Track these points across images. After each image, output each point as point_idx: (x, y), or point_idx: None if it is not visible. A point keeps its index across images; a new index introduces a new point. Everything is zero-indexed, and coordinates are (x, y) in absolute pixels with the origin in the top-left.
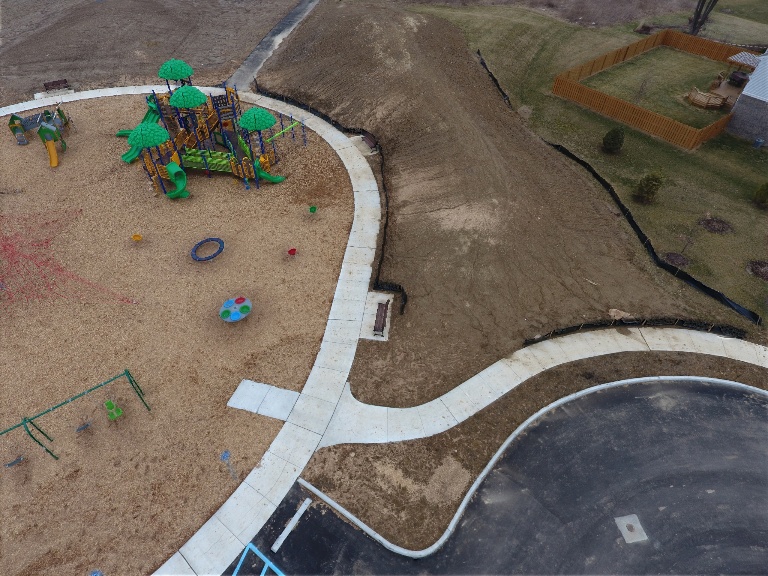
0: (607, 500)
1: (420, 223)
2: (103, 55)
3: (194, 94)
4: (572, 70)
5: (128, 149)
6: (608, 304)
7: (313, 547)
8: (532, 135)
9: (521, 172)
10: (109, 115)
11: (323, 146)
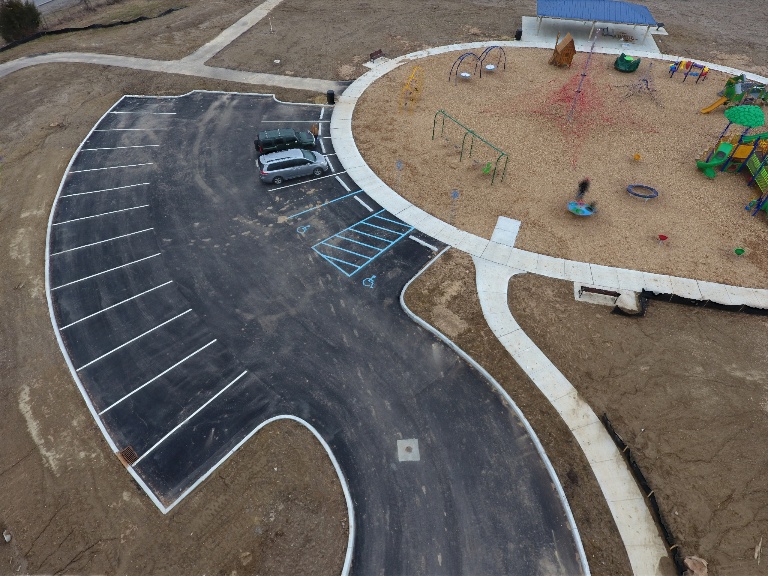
0: (433, 439)
1: None
2: None
3: None
4: None
5: None
6: (717, 563)
7: (410, 252)
8: None
9: None
10: None
11: None
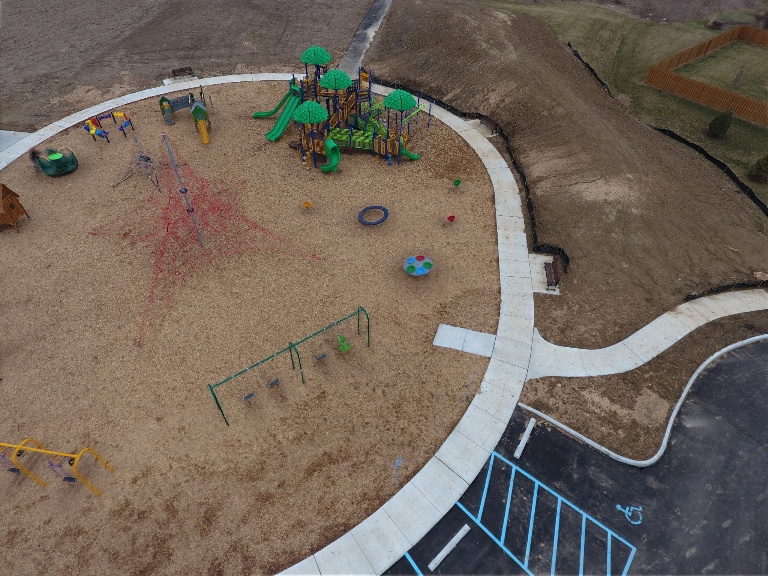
0: None
1: (561, 195)
2: (216, 45)
3: (343, 77)
4: (664, 61)
5: (266, 129)
6: (752, 268)
7: (549, 456)
8: (637, 121)
9: (645, 151)
10: (238, 99)
11: (445, 128)
